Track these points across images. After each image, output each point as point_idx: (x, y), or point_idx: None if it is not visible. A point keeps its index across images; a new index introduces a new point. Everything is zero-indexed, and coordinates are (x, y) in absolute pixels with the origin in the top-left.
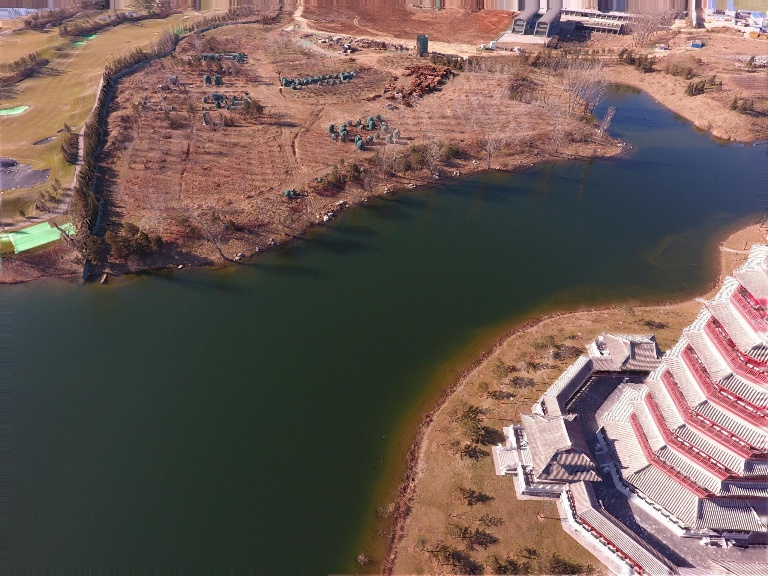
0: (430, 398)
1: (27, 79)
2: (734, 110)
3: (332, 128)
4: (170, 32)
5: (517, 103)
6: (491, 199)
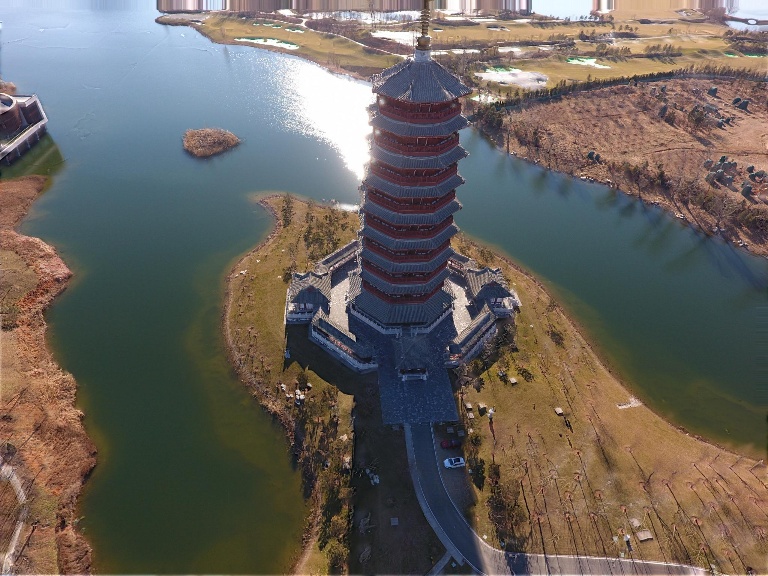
0: None
1: (645, 58)
2: None
3: (723, 159)
4: None
5: None
6: (712, 266)
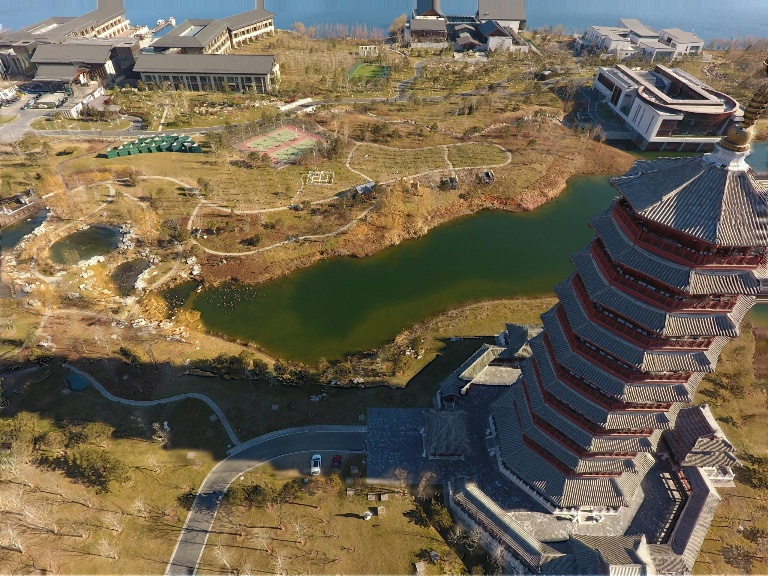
0: None
1: None
2: None
3: None
4: None
5: None
6: None
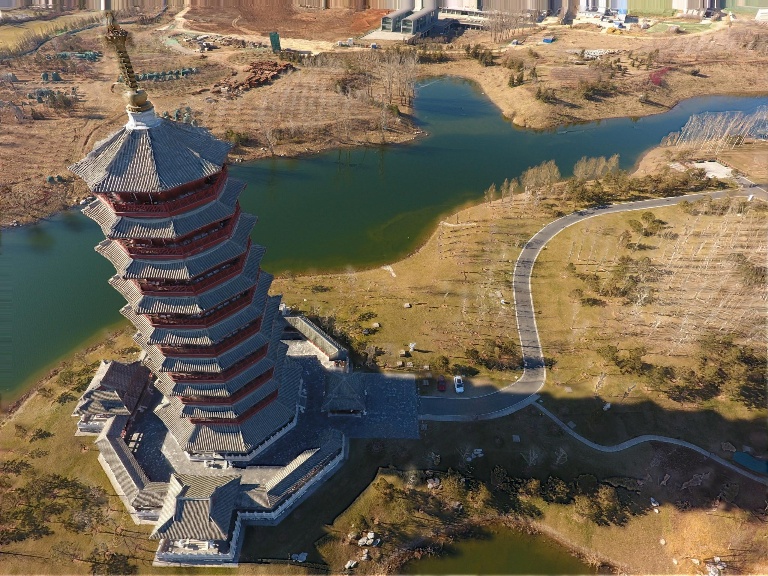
0: (71, 356)
1: None
2: (539, 99)
3: None
4: (36, 32)
5: (337, 95)
6: (257, 183)
